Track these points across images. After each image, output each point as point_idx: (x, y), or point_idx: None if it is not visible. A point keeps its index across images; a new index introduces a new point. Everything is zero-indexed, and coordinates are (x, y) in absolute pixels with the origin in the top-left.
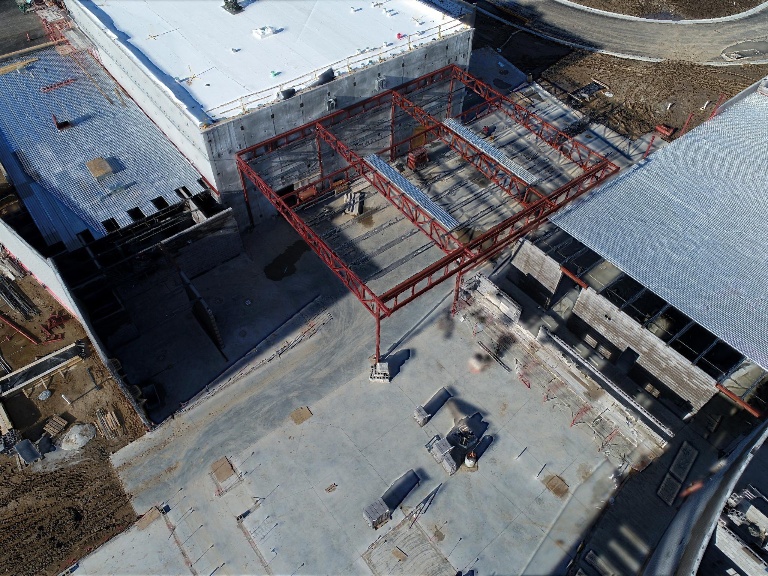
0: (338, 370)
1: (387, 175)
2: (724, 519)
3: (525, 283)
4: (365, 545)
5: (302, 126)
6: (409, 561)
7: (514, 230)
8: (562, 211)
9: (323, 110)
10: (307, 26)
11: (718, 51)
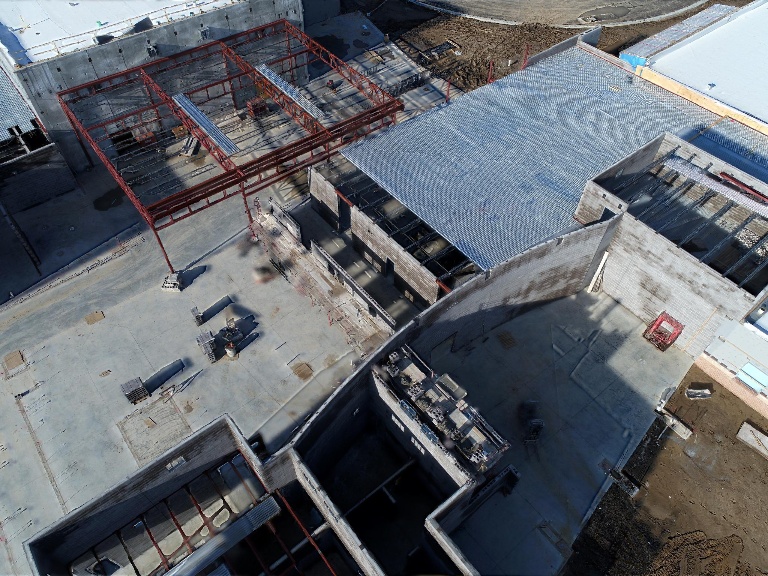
0: (138, 282)
1: (188, 111)
2: (386, 374)
3: (322, 210)
4: (122, 416)
5: (125, 71)
6: (157, 428)
7: None
8: (353, 145)
9: (146, 57)
10: None
11: (576, 15)
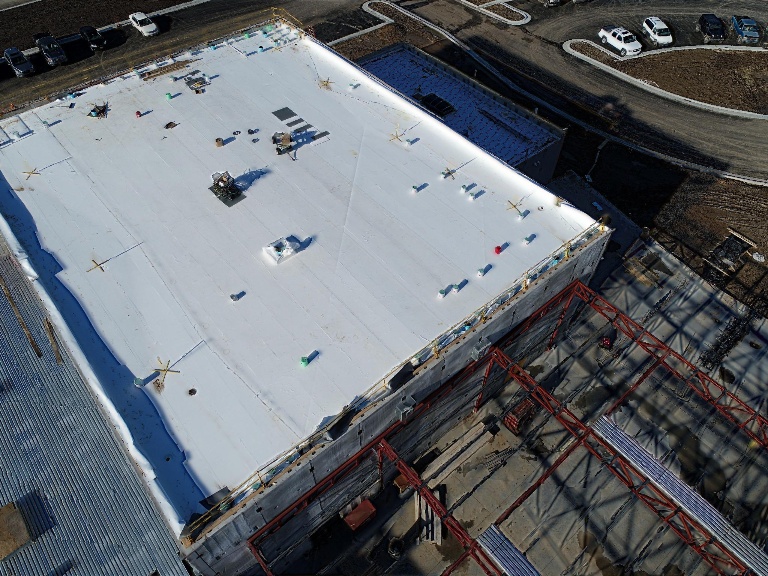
0: None
1: None
2: None
3: None
4: None
5: (358, 452)
6: None
7: (696, 567)
8: None
9: (392, 417)
10: (348, 230)
11: None
